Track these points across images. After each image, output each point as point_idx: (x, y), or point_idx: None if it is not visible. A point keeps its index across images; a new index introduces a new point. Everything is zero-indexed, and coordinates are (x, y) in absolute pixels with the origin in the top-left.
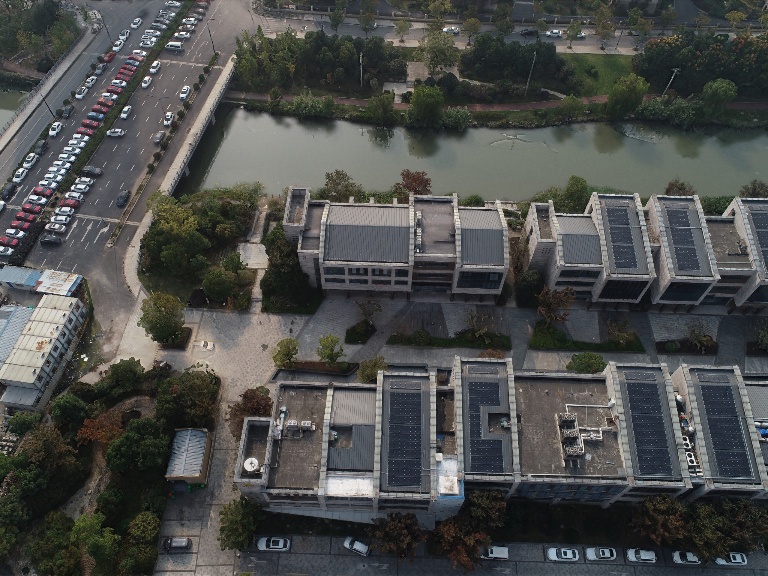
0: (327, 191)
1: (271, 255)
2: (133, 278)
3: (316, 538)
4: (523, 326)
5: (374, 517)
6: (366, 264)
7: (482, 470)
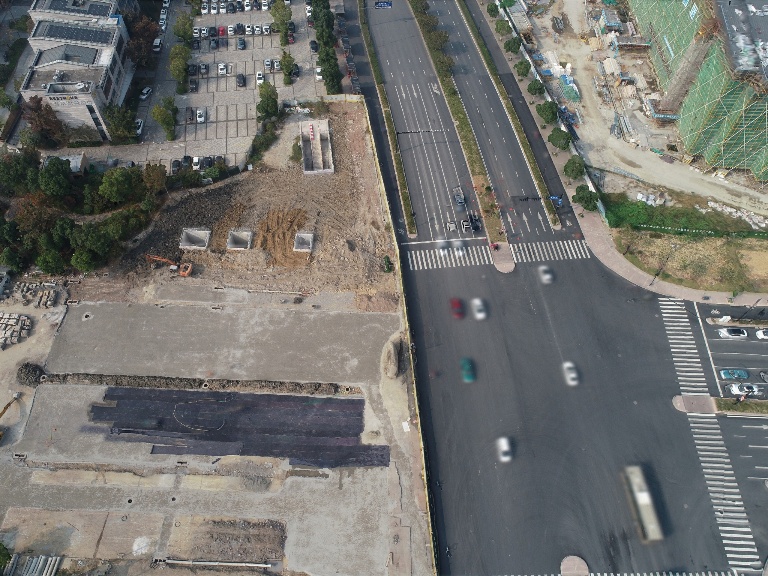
0: None
1: None
2: None
3: (138, 112)
4: (11, 34)
5: (128, 77)
6: None
7: (107, 13)
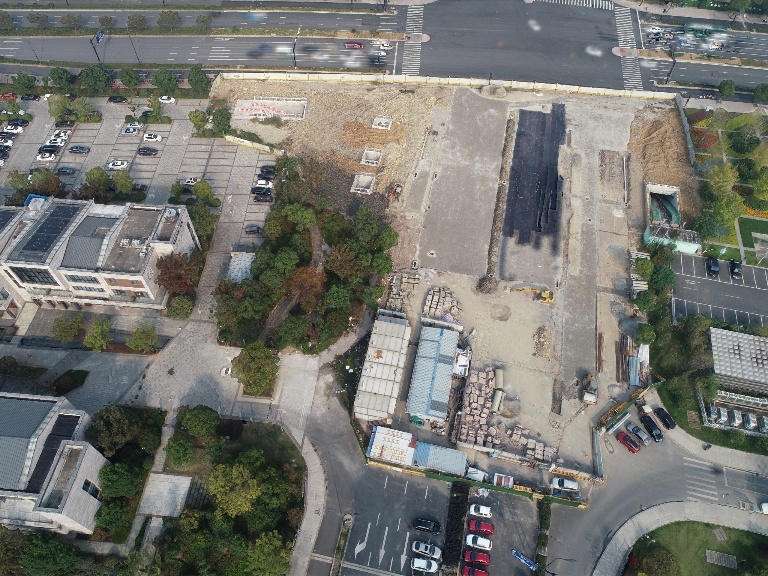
0: (16, 537)
1: (122, 425)
2: (312, 462)
3: None
4: None
5: None
6: (13, 394)
7: (8, 212)
